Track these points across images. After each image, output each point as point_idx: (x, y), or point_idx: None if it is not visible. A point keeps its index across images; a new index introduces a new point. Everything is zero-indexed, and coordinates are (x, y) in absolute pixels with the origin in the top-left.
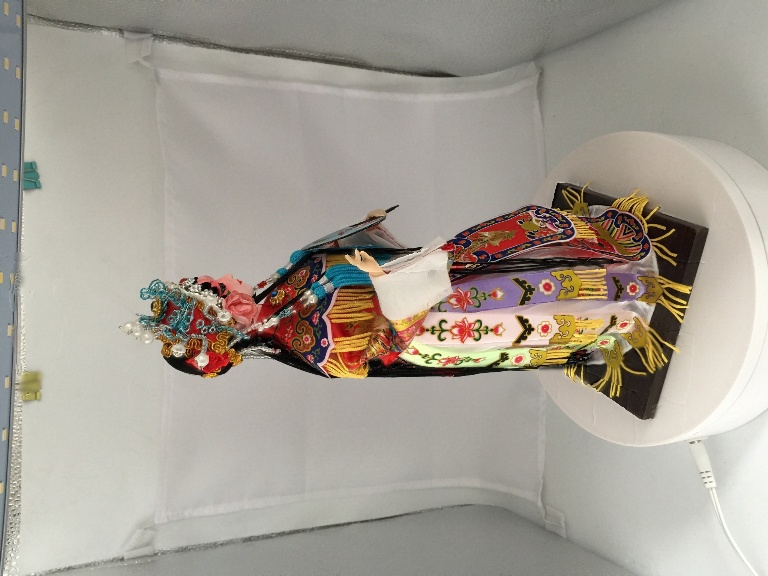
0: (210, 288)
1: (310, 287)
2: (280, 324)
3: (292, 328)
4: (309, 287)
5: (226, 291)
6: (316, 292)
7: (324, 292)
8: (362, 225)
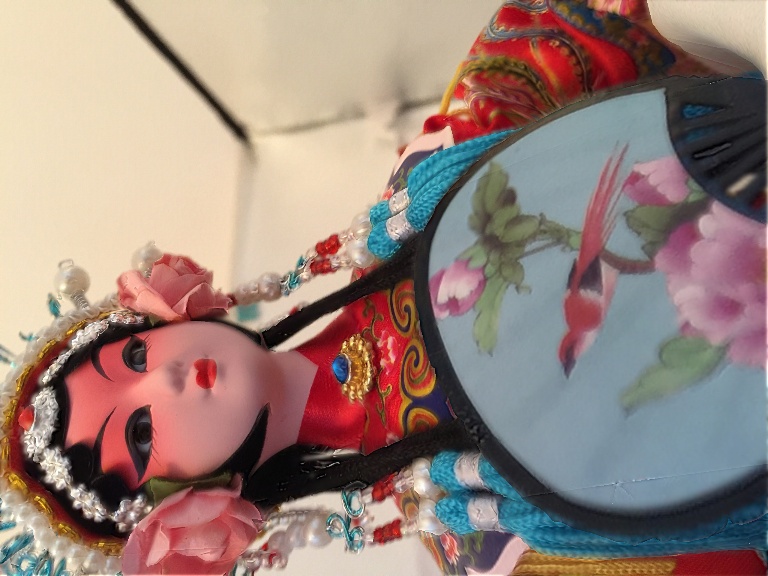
0: (92, 482)
1: (433, 451)
2: (365, 455)
3: (393, 494)
4: (430, 448)
5: (152, 461)
6: (440, 520)
7: (470, 530)
8: (712, 293)
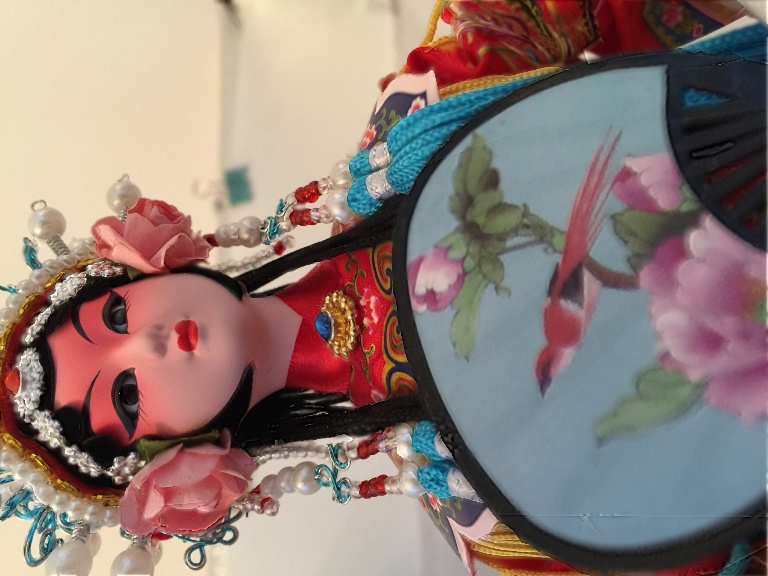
0: (84, 443)
1: (415, 419)
2: None
3: None
4: (412, 416)
5: (141, 421)
6: (422, 485)
7: (450, 496)
8: (696, 324)
